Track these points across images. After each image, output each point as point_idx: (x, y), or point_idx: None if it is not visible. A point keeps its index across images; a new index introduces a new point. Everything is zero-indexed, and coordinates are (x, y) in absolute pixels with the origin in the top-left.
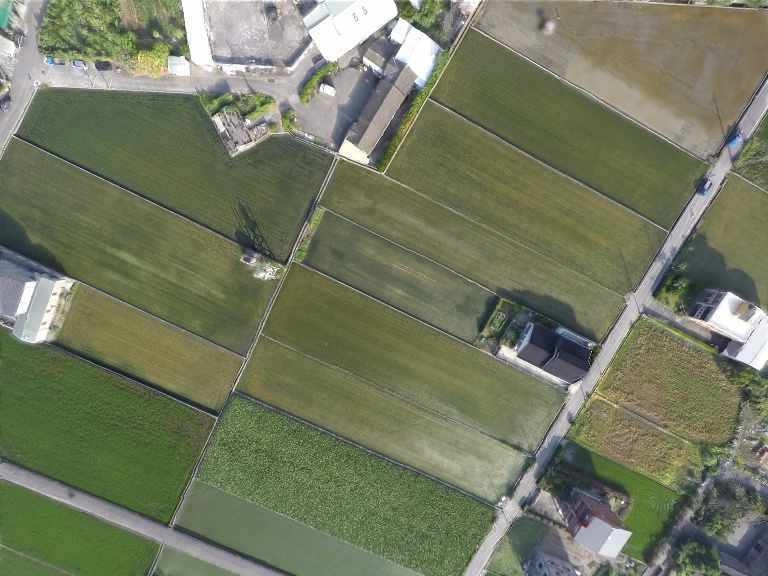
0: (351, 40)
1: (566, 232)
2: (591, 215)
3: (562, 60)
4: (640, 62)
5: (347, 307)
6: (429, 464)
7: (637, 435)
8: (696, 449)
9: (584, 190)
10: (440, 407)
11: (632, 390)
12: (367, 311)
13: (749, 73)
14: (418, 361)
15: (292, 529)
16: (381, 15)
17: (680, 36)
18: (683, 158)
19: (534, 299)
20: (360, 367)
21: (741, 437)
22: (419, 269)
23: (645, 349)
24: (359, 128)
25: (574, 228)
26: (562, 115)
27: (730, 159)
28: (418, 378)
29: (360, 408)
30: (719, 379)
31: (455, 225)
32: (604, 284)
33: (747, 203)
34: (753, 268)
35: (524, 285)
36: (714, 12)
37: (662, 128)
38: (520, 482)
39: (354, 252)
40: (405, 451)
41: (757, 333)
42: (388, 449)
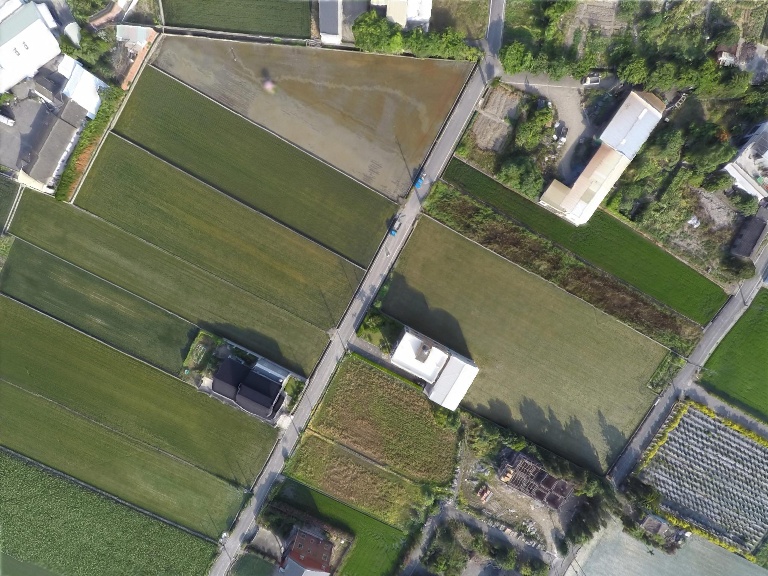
0: (16, 73)
1: (262, 267)
2: (286, 251)
3: (243, 100)
4: (320, 104)
5: (45, 335)
6: (144, 498)
7: (356, 472)
8: (417, 488)
9: (276, 226)
10: (151, 439)
11: (346, 427)
12: (66, 340)
13: (429, 119)
14: (122, 392)
15: (3, 563)
16: (44, 50)
17: (357, 81)
18: (372, 198)
19: (237, 332)
20: (65, 396)
21: (462, 477)
22: (116, 299)
23: (355, 385)
24: (31, 159)
25: (270, 263)
26: (248, 152)
27: (419, 201)
28: (125, 409)
29: (69, 438)
30: (431, 418)
31: (149, 256)
32: (307, 319)
33: (441, 244)
34: (455, 308)
35: (225, 318)
36: (387, 60)
37: (349, 168)
38: (239, 518)
39: (49, 280)
40: (118, 484)
41: (447, 374)
42: (102, 481)
